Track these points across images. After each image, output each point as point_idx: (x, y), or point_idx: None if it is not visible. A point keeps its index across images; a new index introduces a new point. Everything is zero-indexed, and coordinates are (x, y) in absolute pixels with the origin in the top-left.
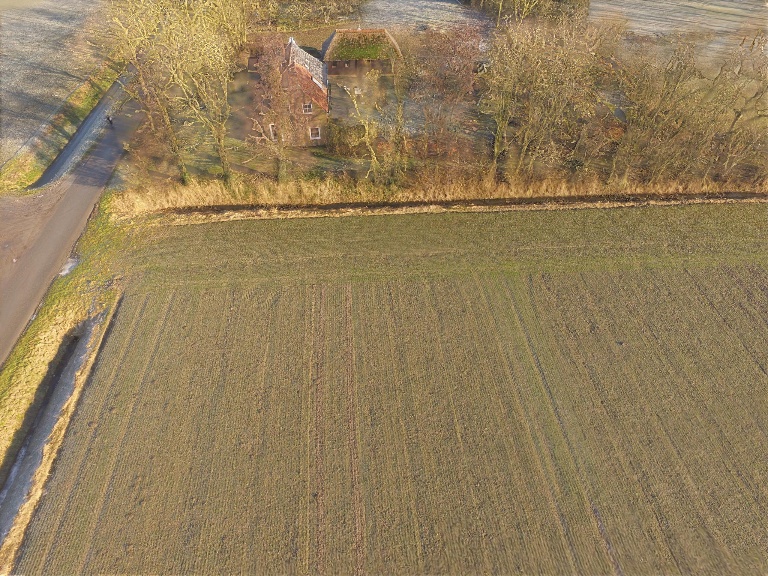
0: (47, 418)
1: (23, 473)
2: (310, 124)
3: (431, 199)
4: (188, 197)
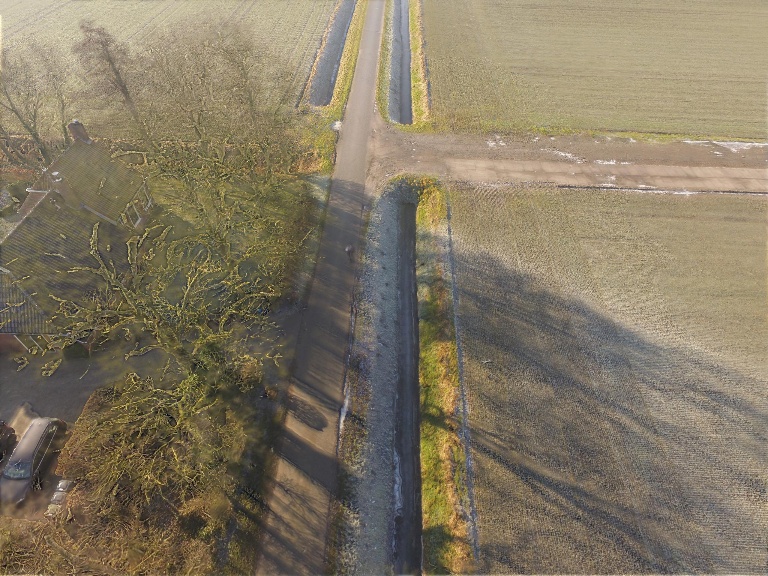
0: None
1: None
2: None
3: None
4: None
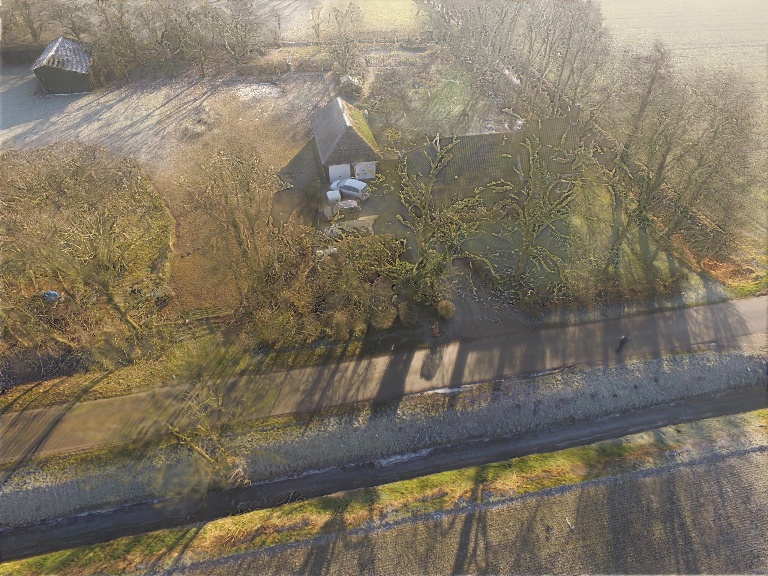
0: None
1: None
2: None
3: None
4: None
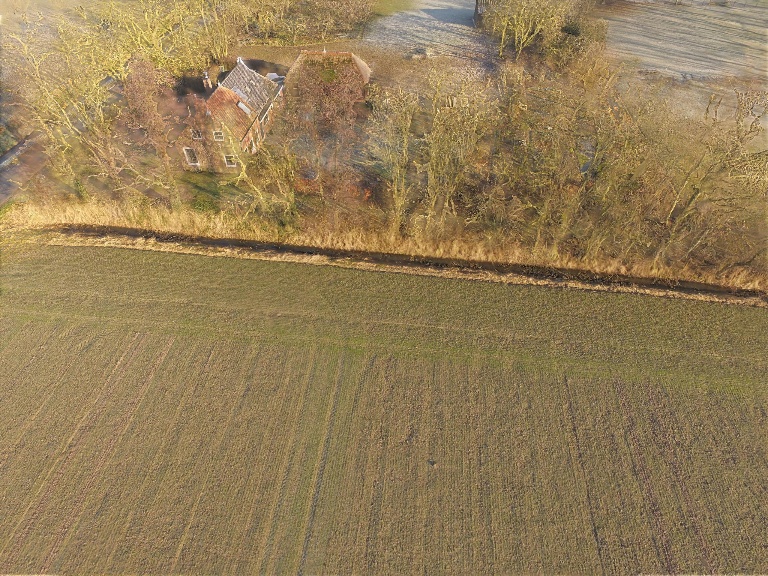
0: None
1: None
2: (224, 151)
3: (328, 246)
4: (83, 215)
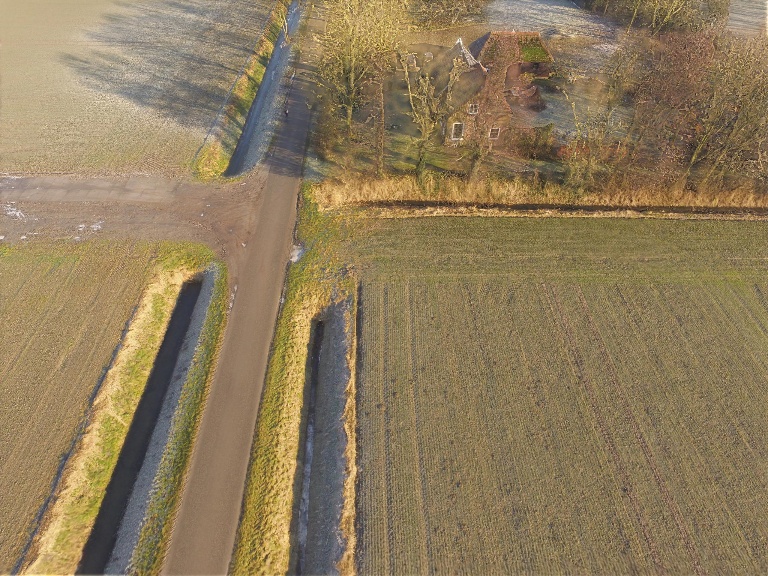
0: (326, 398)
1: (325, 449)
2: None
3: (616, 204)
4: (381, 191)
